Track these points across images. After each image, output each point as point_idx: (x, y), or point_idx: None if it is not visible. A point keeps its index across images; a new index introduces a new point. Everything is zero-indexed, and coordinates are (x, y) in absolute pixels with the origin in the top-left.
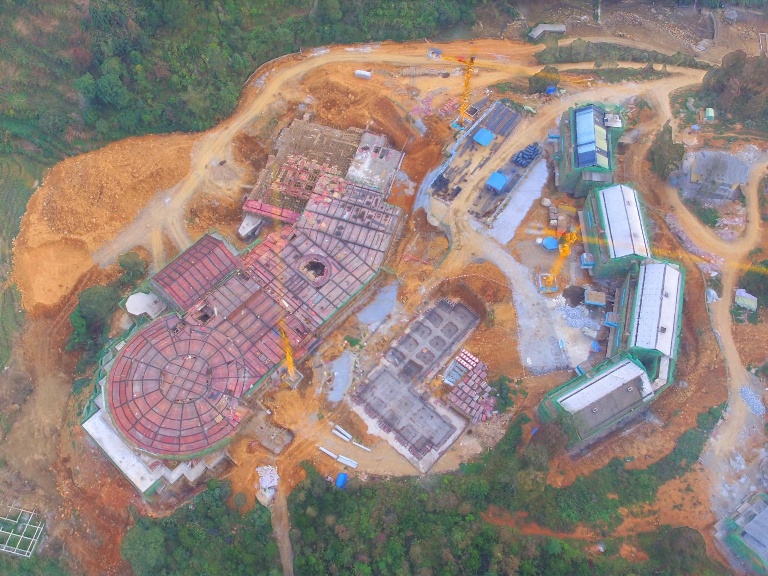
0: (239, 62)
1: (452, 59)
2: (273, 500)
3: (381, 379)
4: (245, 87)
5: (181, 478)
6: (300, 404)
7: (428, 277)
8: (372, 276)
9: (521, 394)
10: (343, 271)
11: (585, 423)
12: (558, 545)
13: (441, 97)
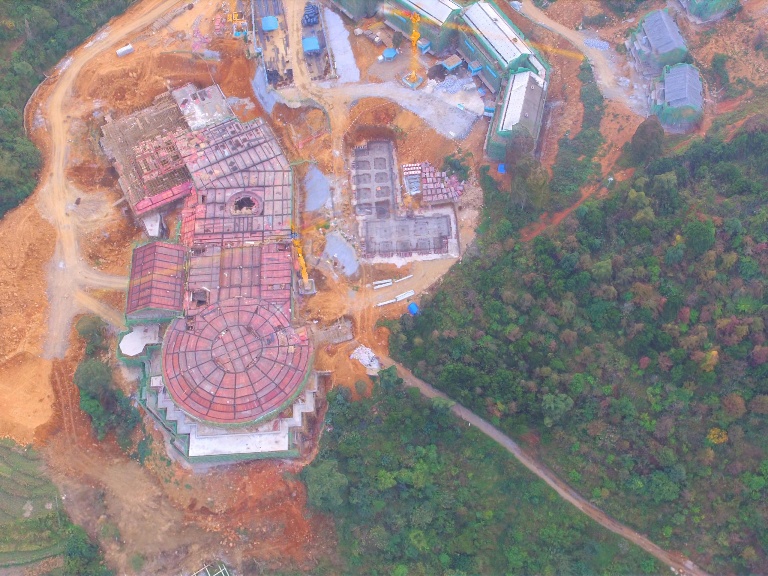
0: (8, 115)
1: None
2: (382, 366)
3: (370, 230)
4: (30, 136)
5: (303, 417)
6: (333, 295)
7: (331, 142)
8: (291, 175)
9: (468, 157)
10: (267, 189)
11: (528, 128)
12: (584, 206)
13: (204, 24)
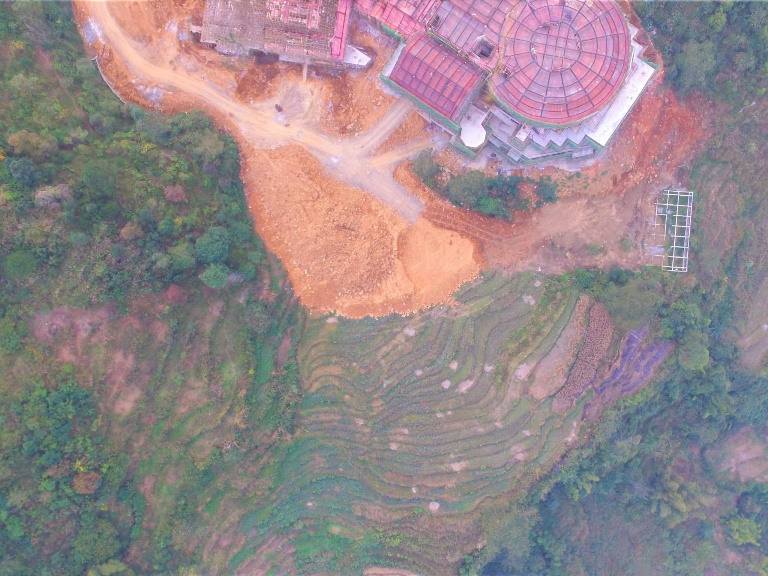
0: (141, 111)
1: None
2: None
3: None
4: None
5: None
6: None
7: None
8: None
9: None
10: None
11: None
12: None
13: None
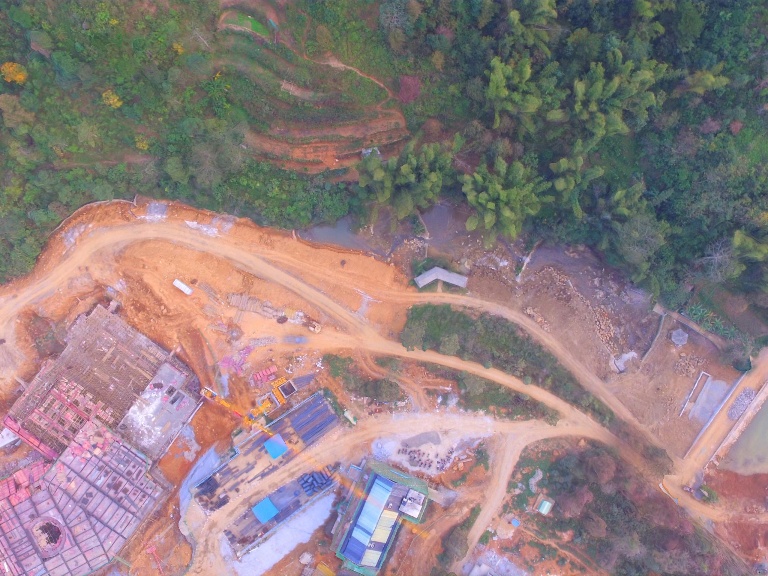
0: (40, 220)
1: (305, 287)
2: None
3: None
4: (53, 236)
5: None
6: None
7: None
8: (104, 563)
9: None
10: (76, 548)
11: None
12: None
13: (264, 351)
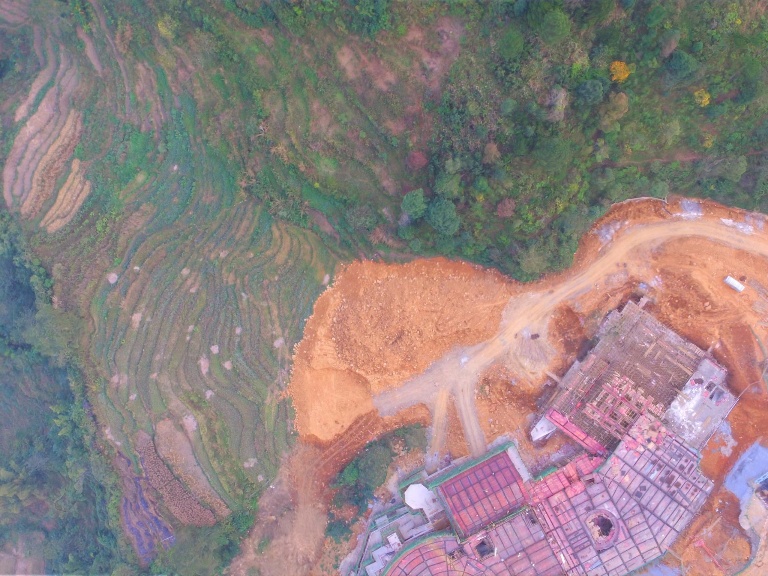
0: None
1: None
2: None
3: None
4: (586, 233)
5: None
6: None
7: None
8: (657, 556)
9: None
10: (630, 540)
11: None
12: None
13: None
